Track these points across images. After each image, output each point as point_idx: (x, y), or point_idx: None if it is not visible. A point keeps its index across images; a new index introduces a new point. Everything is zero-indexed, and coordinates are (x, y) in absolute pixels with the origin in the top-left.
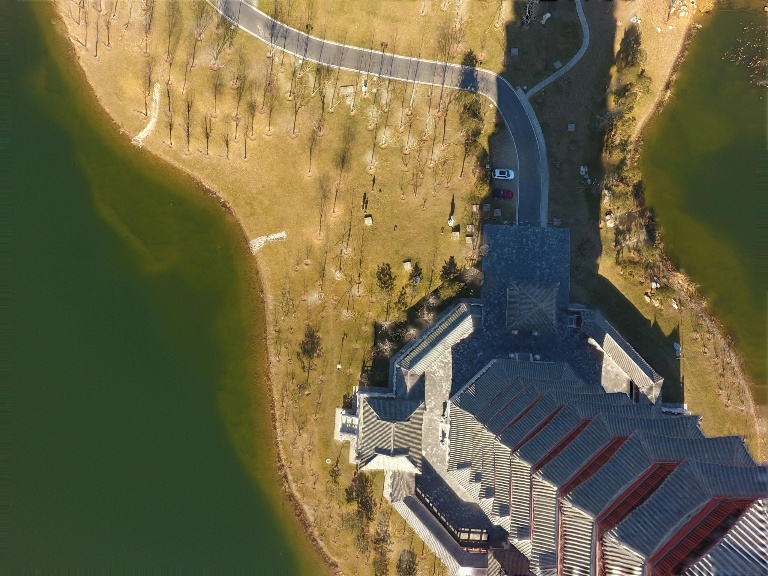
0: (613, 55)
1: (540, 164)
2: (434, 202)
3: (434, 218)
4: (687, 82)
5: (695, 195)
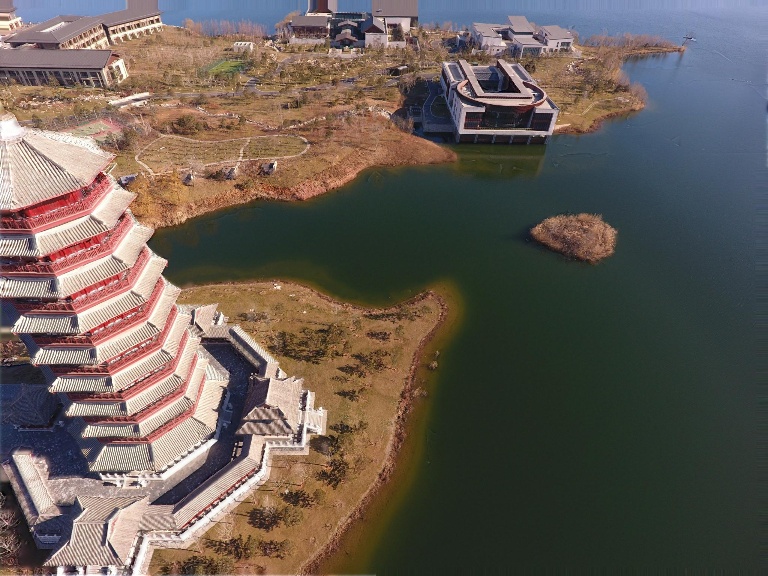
0: None
1: None
2: None
3: None
4: None
5: None
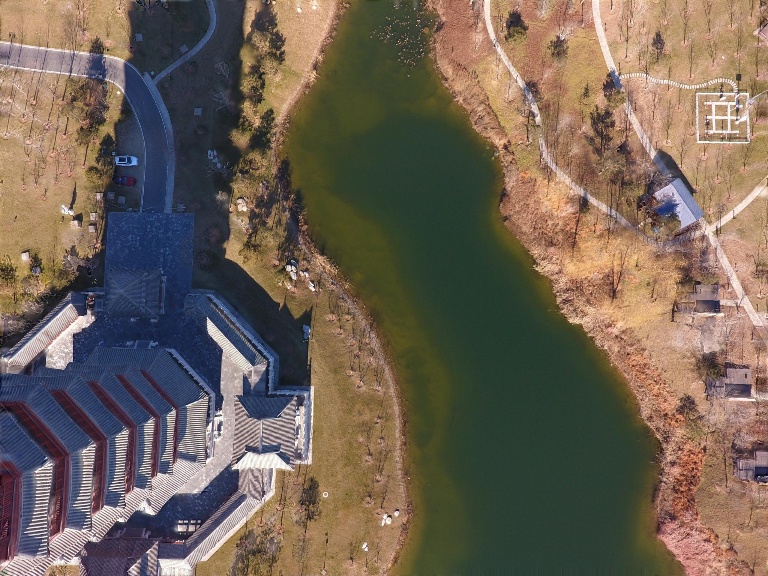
0: (242, 37)
1: (167, 150)
2: (55, 191)
3: (55, 208)
4: (337, 62)
5: (346, 176)
